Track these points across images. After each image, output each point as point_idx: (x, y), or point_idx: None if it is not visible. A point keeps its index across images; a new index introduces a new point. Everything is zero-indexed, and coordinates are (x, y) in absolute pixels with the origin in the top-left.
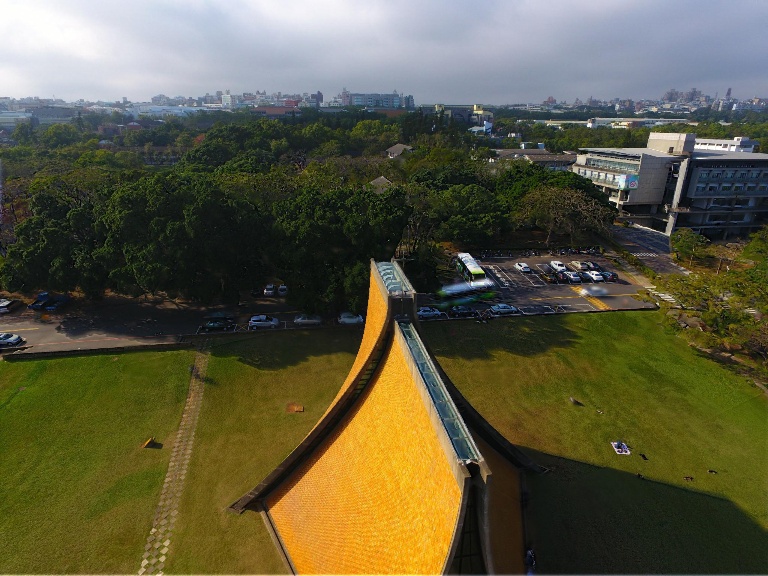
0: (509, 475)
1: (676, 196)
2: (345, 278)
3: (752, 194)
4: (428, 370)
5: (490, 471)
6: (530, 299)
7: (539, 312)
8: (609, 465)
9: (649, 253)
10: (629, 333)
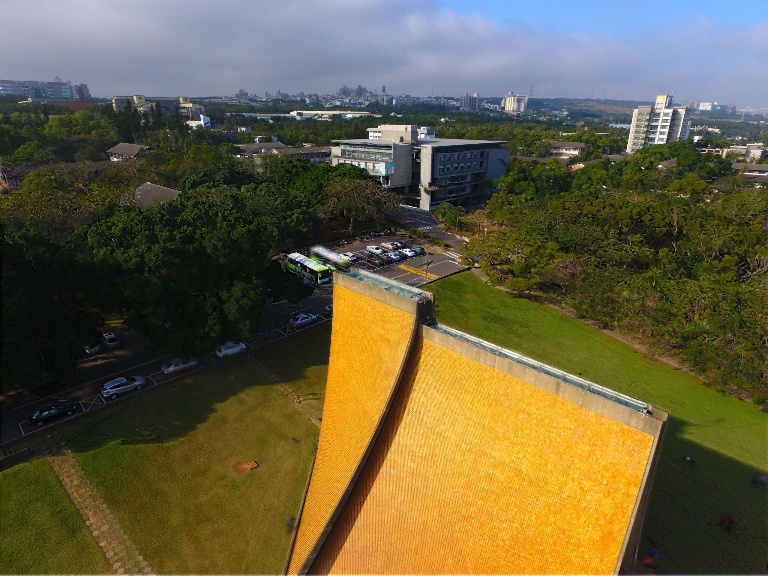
0: None
1: (425, 177)
2: None
3: (470, 171)
4: None
5: None
6: None
7: None
8: None
9: (425, 227)
10: (464, 293)
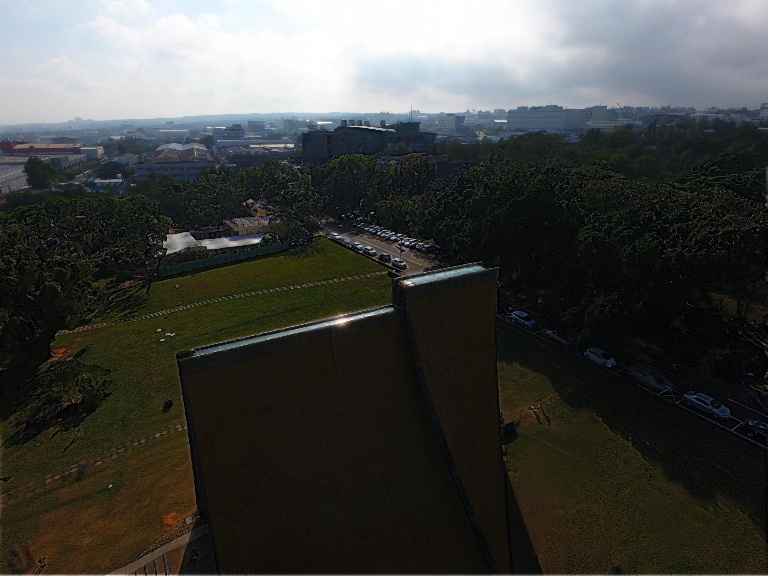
0: (458, 553)
1: None
2: None
3: None
4: None
5: (182, 360)
6: None
7: None
8: None
9: None
10: None
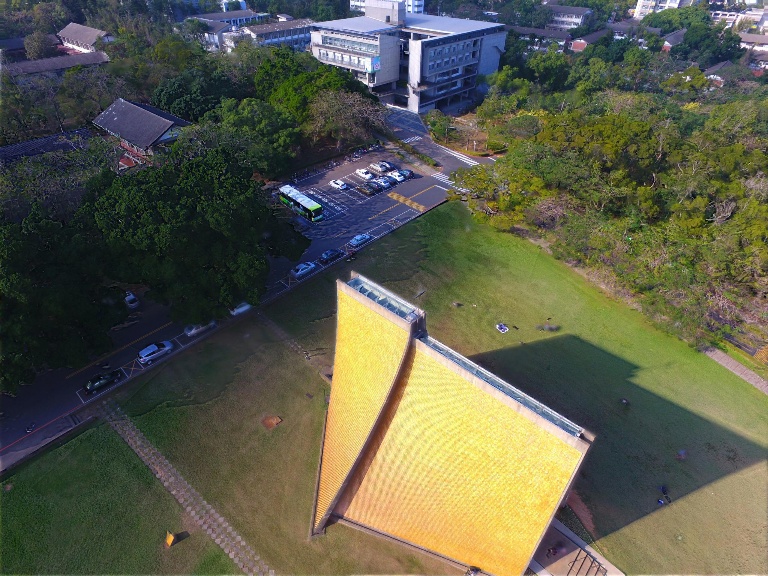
0: None
1: (413, 74)
2: (234, 275)
3: (462, 64)
4: (482, 375)
5: None
6: (368, 219)
7: (385, 232)
8: (504, 344)
9: (414, 137)
10: (451, 228)
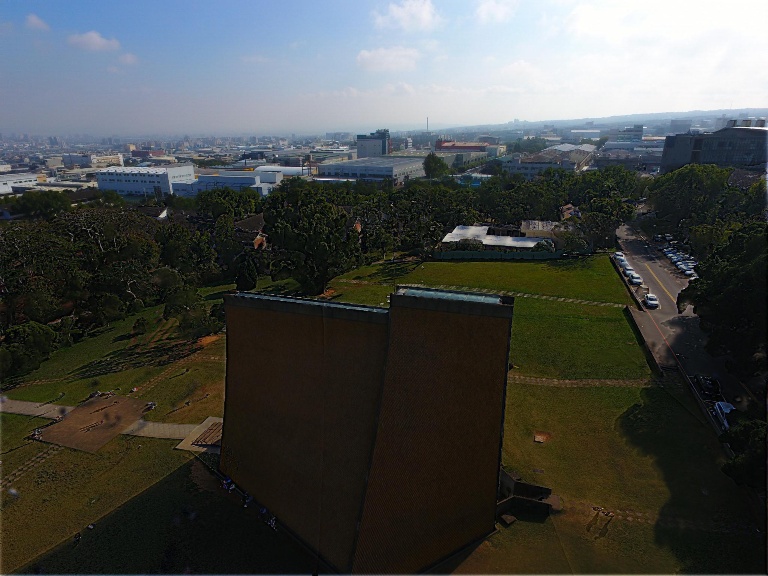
0: (344, 547)
1: None
2: None
3: None
4: None
5: None
6: None
7: None
8: None
9: None
10: None
